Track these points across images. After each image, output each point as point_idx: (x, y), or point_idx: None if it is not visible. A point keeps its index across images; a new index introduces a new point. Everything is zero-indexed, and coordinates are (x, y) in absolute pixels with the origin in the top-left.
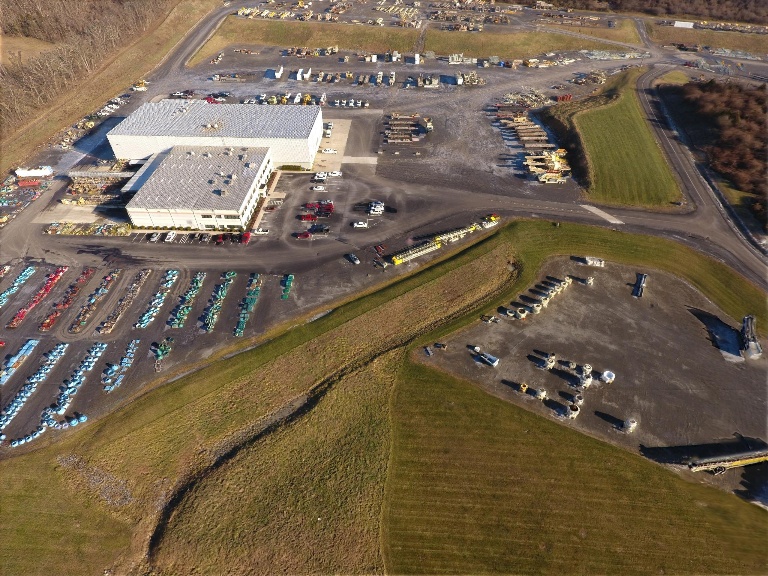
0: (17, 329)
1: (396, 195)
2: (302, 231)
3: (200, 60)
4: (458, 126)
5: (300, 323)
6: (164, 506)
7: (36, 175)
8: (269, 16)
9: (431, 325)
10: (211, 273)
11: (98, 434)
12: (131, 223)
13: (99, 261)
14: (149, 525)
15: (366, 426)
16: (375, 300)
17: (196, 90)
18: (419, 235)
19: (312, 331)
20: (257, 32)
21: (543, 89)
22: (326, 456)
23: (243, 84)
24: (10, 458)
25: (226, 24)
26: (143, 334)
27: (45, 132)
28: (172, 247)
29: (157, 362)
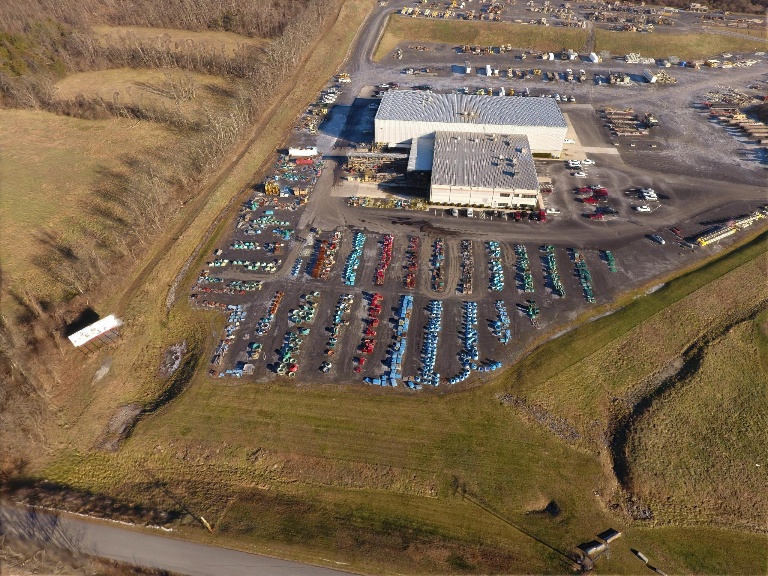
0: (385, 286)
1: (659, 183)
2: (590, 212)
3: (382, 55)
4: (676, 122)
5: (642, 294)
6: (609, 443)
7: (306, 155)
8: (433, 15)
9: (765, 302)
10: (529, 246)
11: (521, 378)
12: (426, 199)
13: (417, 231)
14: (607, 458)
15: (753, 388)
16: (704, 277)
17: (397, 83)
18: (706, 220)
19: (660, 301)
20: (424, 30)
21: (741, 89)
22: (732, 412)
23: (437, 78)
24: (455, 393)
25: (393, 22)
26: (503, 296)
27: (286, 117)
28: (476, 222)
29: (533, 320)
